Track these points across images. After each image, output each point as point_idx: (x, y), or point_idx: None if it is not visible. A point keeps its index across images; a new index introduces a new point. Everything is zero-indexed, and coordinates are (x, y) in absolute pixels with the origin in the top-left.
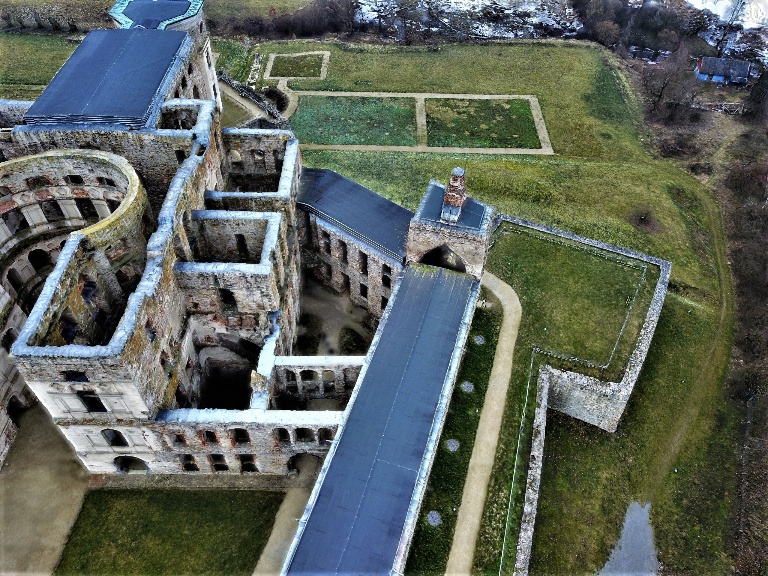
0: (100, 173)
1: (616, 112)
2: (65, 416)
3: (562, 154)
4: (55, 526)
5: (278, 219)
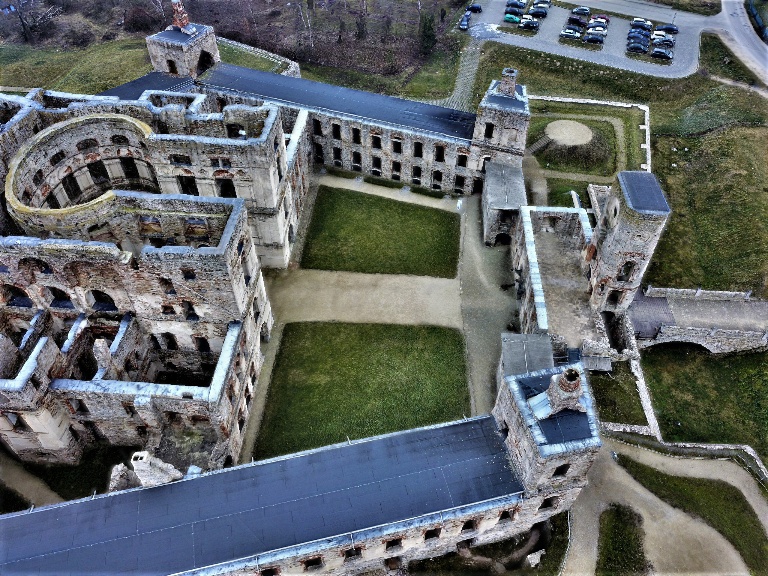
0: (51, 152)
1: (13, 54)
2: (277, 200)
3: (45, 85)
4: (323, 279)
5: (153, 90)
